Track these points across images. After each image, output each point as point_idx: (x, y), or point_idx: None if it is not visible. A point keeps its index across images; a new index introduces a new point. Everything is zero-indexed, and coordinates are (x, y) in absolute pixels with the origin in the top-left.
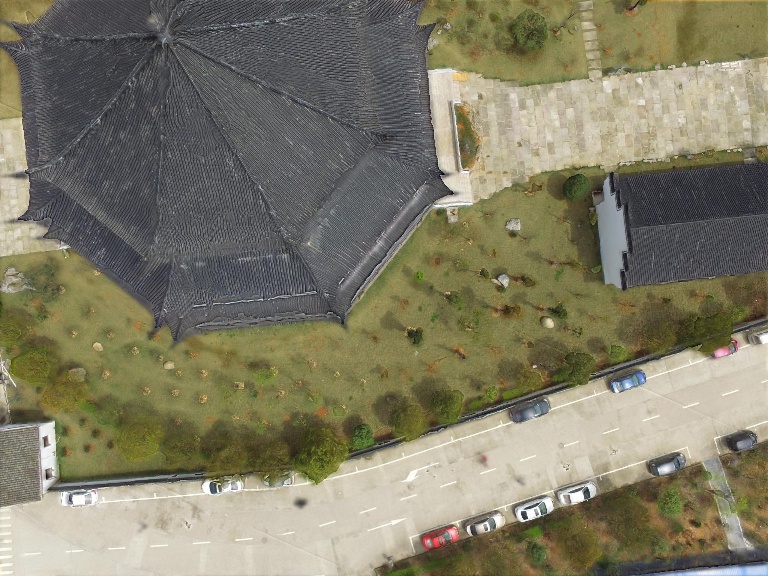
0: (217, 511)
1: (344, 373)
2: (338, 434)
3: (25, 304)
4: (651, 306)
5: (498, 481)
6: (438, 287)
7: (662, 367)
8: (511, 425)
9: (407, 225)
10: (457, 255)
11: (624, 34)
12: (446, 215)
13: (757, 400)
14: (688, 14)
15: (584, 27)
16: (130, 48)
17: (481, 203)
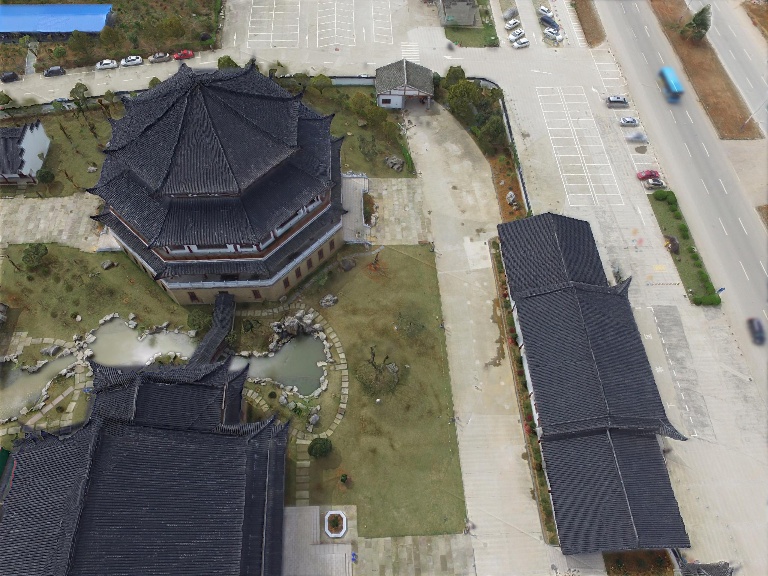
0: (297, 72)
1: None
2: None
3: (390, 155)
4: None
5: (147, 73)
6: None
7: None
8: None
9: None
10: None
11: None
12: None
13: None
14: None
15: None
16: (223, 99)
17: None
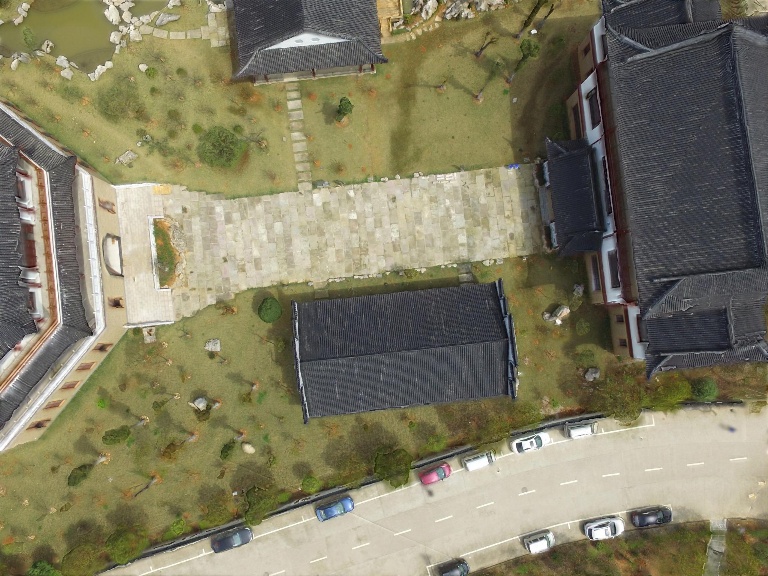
0: None
1: (33, 502)
2: (28, 566)
3: None
4: (359, 429)
5: None
6: (134, 411)
7: (373, 492)
8: (214, 554)
9: (47, 367)
10: (155, 377)
11: (334, 145)
12: (143, 335)
13: (471, 526)
14: (402, 124)
15: (294, 138)
16: None
17: (183, 321)
